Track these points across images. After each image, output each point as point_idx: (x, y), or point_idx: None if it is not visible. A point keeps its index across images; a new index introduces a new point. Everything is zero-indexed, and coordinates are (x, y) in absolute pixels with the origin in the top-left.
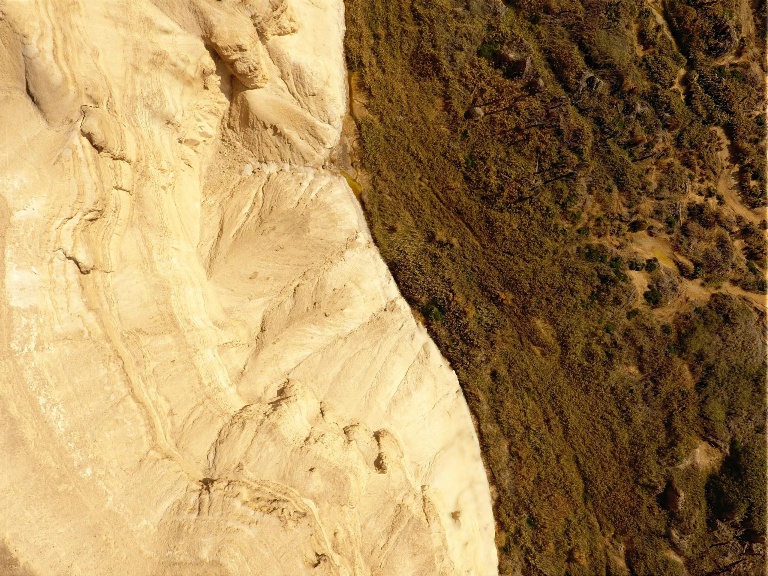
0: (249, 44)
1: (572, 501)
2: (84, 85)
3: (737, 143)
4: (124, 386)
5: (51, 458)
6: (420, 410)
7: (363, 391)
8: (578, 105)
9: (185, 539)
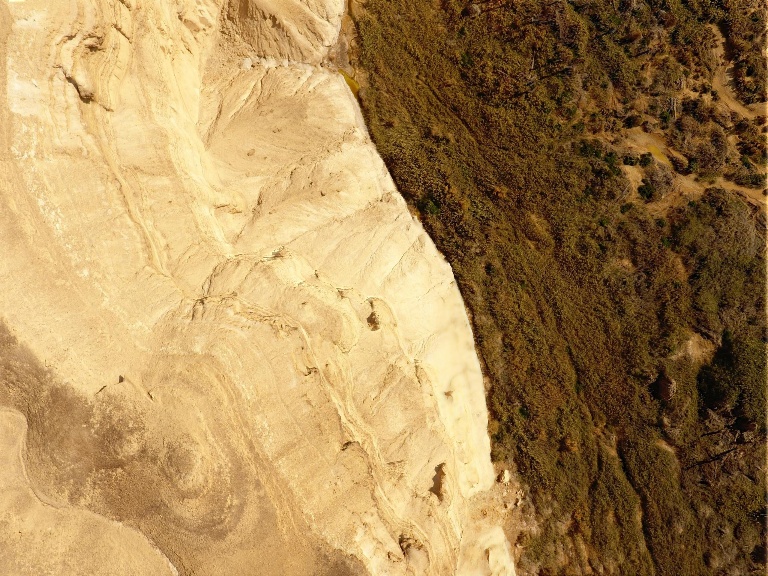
0: None
1: (565, 391)
2: None
3: (732, 39)
4: (121, 206)
5: (49, 255)
6: (414, 291)
7: (358, 268)
8: (574, 3)
9: (179, 337)
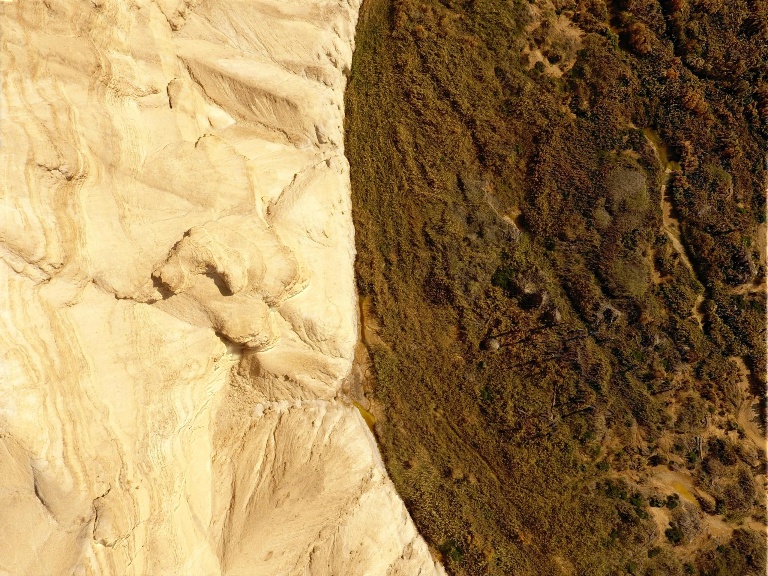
0: (261, 326)
1: None
2: (95, 473)
3: (757, 376)
4: None
5: None
6: None
7: None
8: (595, 335)
9: None
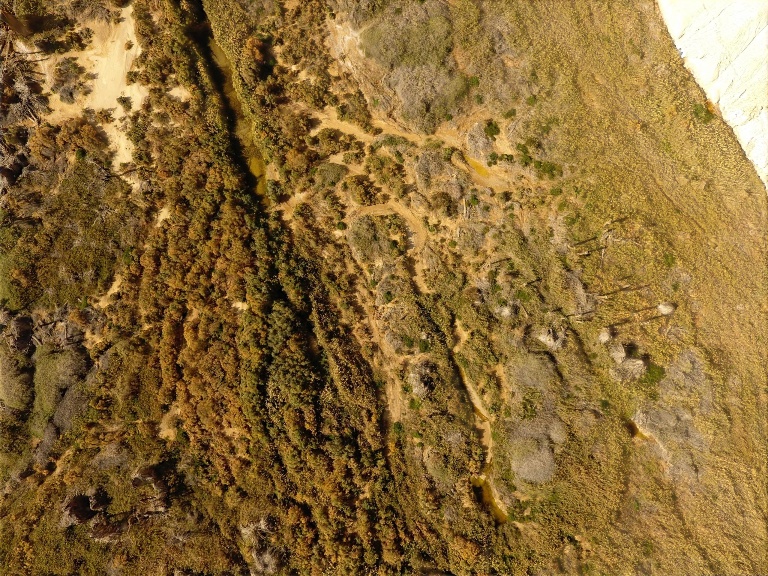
0: None
1: None
2: None
3: (411, 275)
4: None
5: None
6: (747, 2)
7: None
8: (562, 316)
9: None
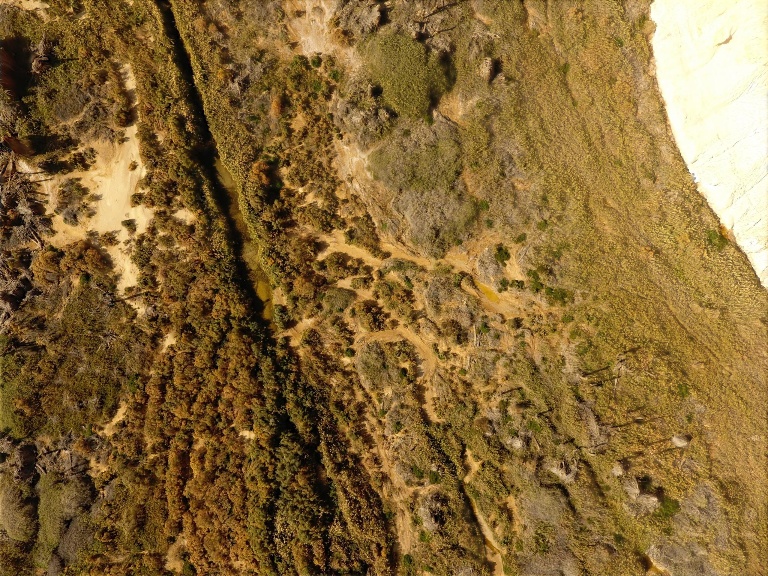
0: None
1: (581, 64)
2: None
3: (420, 405)
4: None
5: None
6: (763, 138)
7: None
8: (575, 447)
9: None
